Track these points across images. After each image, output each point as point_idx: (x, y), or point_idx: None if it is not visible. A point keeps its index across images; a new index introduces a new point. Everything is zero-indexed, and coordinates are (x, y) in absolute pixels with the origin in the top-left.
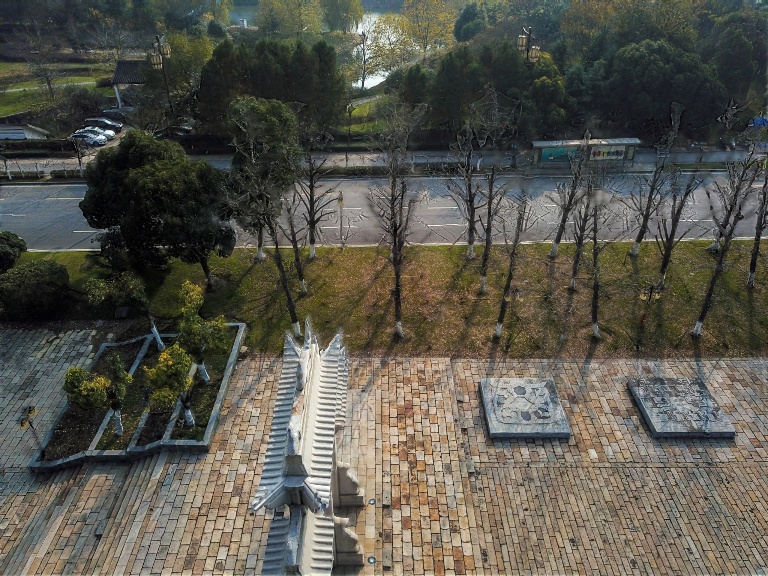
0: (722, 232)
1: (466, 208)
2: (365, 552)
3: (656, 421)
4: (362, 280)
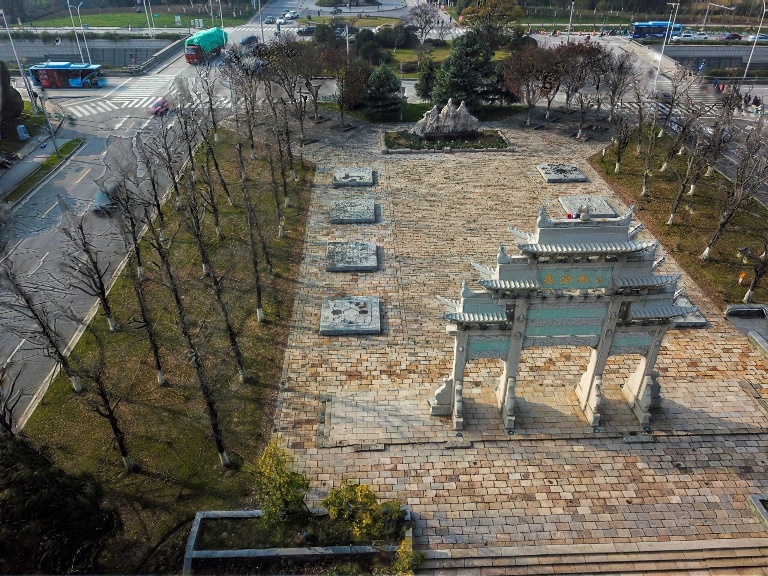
0: (267, 161)
1: (92, 284)
2: (493, 393)
3: (368, 264)
4: (125, 412)
